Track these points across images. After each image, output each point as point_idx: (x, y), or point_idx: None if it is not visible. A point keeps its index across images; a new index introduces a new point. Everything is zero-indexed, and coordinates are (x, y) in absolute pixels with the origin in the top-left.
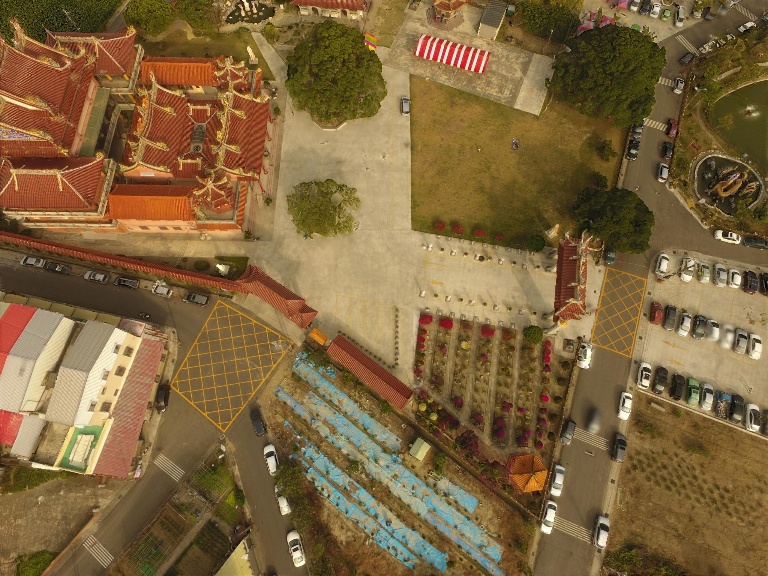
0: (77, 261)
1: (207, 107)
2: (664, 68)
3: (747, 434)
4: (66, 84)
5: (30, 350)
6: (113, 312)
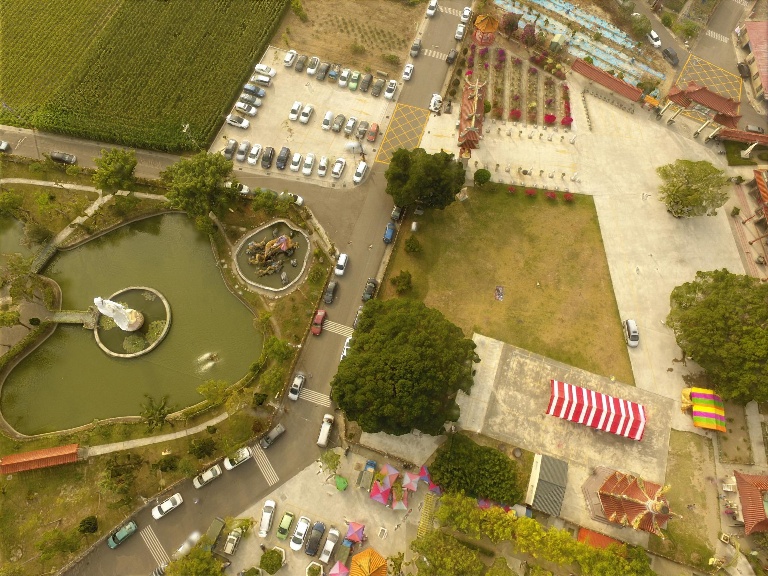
0: None
1: None
2: (308, 419)
3: None
4: None
5: None
6: None
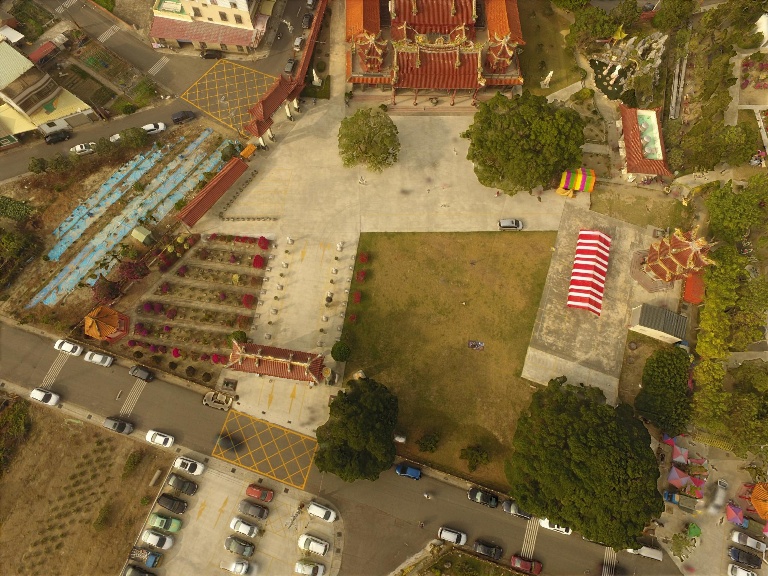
0: None
1: None
2: (633, 572)
3: None
4: None
5: None
6: (283, 17)
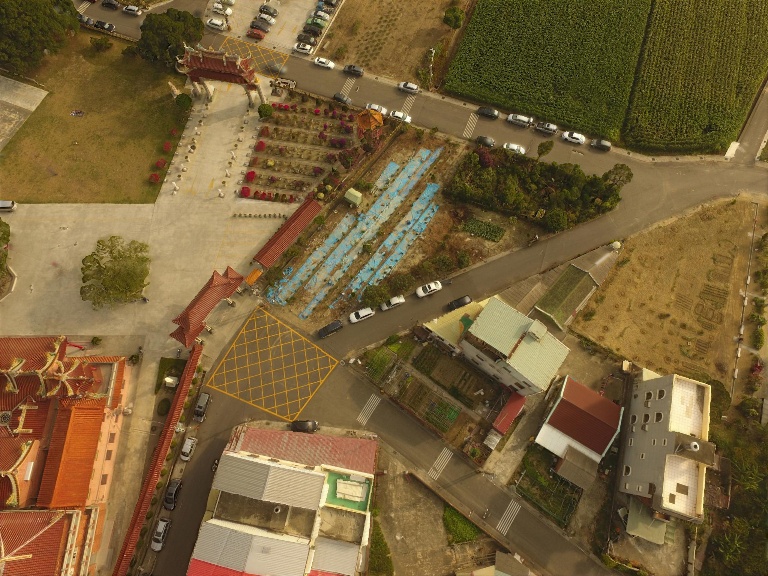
0: (135, 570)
1: None
2: None
3: (346, 1)
4: None
5: (241, 547)
6: None
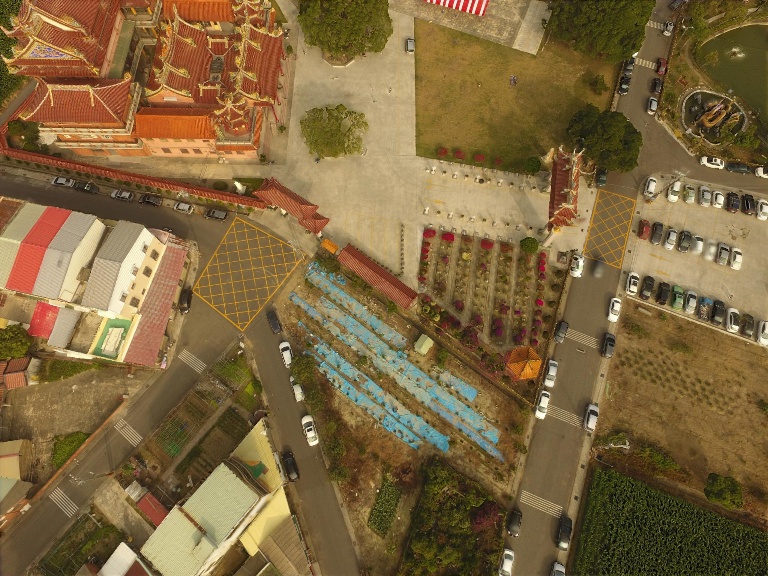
0: (104, 182)
1: (225, 40)
2: (655, 13)
3: (728, 336)
4: (97, 9)
5: (67, 245)
6: None
